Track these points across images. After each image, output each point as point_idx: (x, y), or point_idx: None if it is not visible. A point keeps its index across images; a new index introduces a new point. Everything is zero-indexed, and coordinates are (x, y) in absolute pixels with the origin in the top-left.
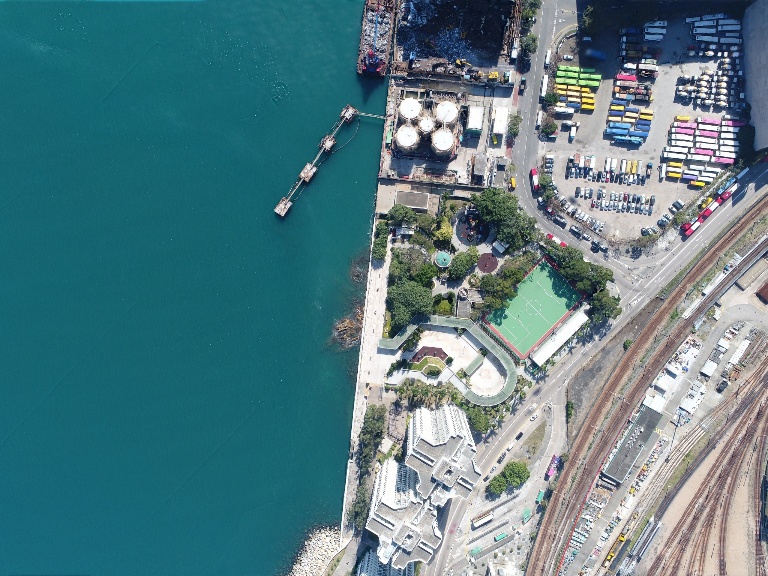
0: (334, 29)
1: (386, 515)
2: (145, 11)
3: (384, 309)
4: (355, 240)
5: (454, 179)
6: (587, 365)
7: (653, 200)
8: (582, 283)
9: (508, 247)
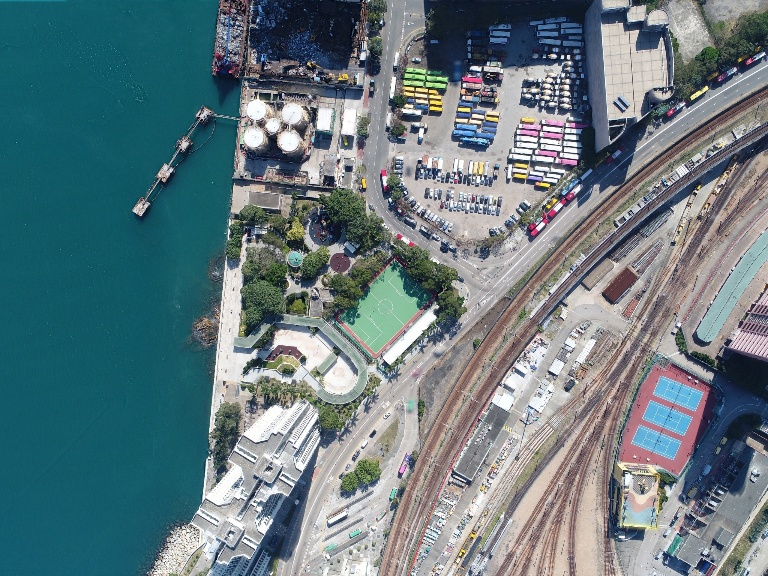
0: (190, 31)
1: (211, 511)
2: None
3: (240, 308)
4: (213, 240)
5: (305, 180)
6: (438, 364)
7: (500, 201)
8: (427, 283)
9: (359, 247)
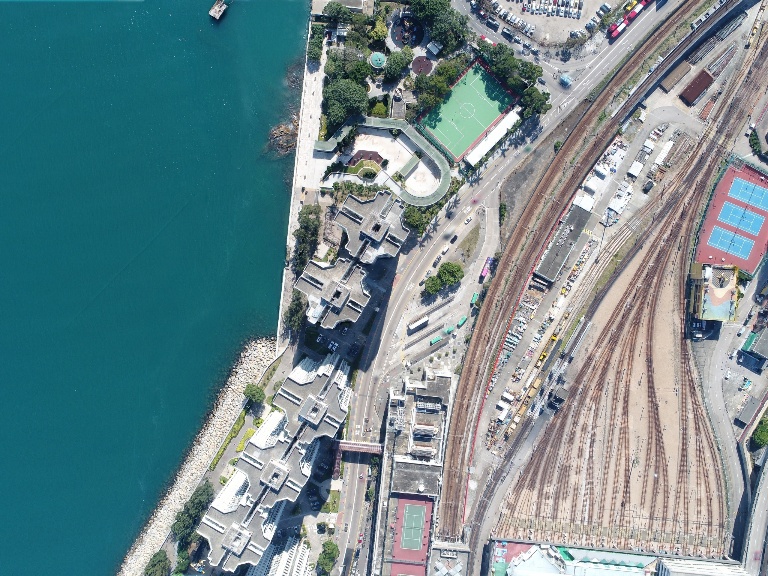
0: None
1: (315, 274)
2: None
3: (320, 113)
4: (291, 45)
5: None
6: (519, 167)
7: (581, 3)
8: (513, 79)
9: (442, 49)
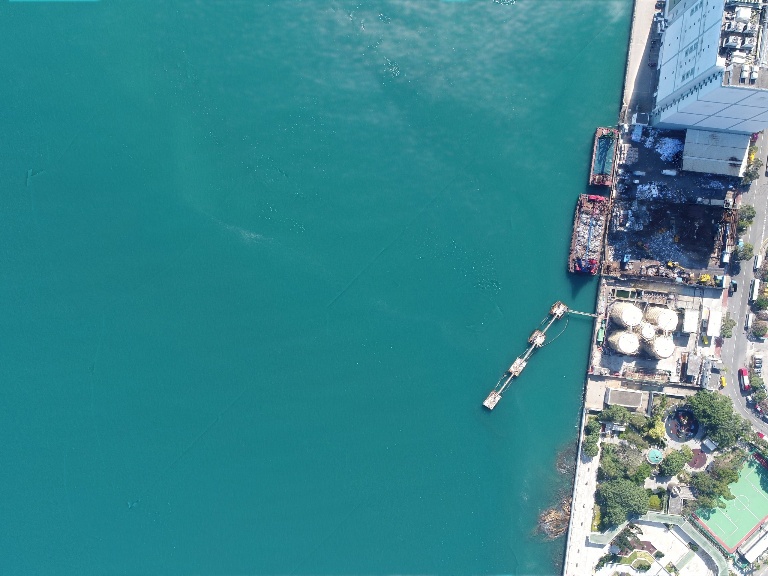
0: (544, 227)
1: None
2: (373, 220)
3: (593, 502)
4: (562, 432)
5: (666, 378)
6: None
7: None
8: None
9: (718, 444)
